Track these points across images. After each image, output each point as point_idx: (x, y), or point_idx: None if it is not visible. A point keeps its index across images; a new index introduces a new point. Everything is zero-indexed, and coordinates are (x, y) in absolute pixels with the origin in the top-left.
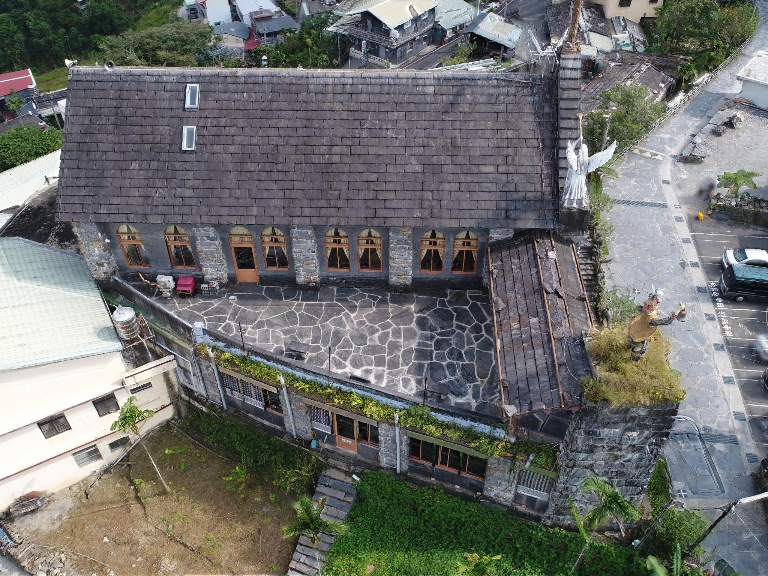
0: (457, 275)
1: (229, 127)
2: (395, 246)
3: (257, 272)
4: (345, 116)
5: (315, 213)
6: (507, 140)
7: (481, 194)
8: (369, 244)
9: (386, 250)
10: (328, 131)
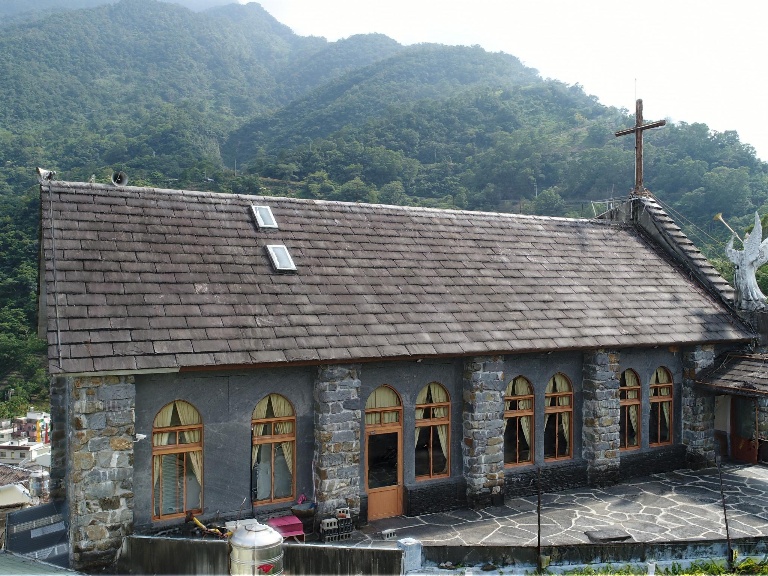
0: (657, 447)
1: (333, 250)
2: (601, 392)
3: (399, 491)
4: (471, 244)
5: (509, 336)
6: (644, 267)
7: (665, 311)
8: (556, 406)
9: (579, 412)
10: (463, 256)
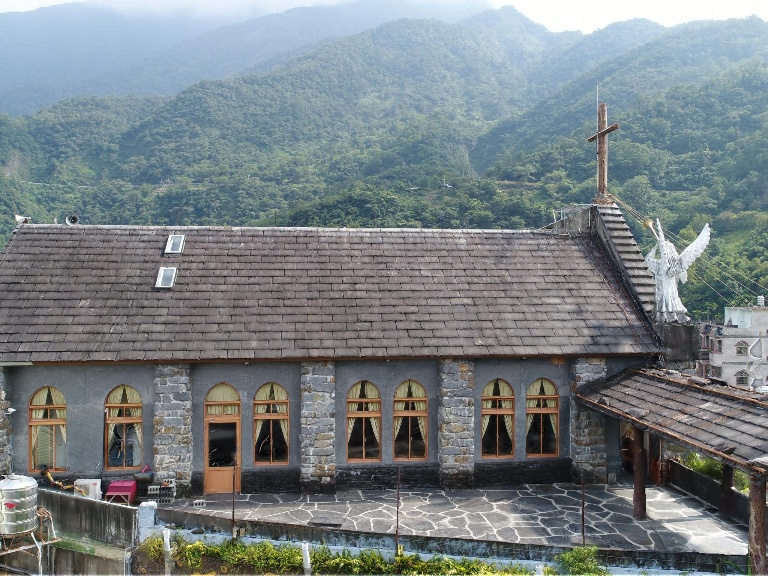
0: (535, 458)
1: (220, 270)
2: (450, 399)
3: (238, 472)
4: (367, 260)
5: (340, 344)
6: (564, 277)
7: (553, 323)
8: (409, 410)
9: (434, 417)
10: (348, 272)
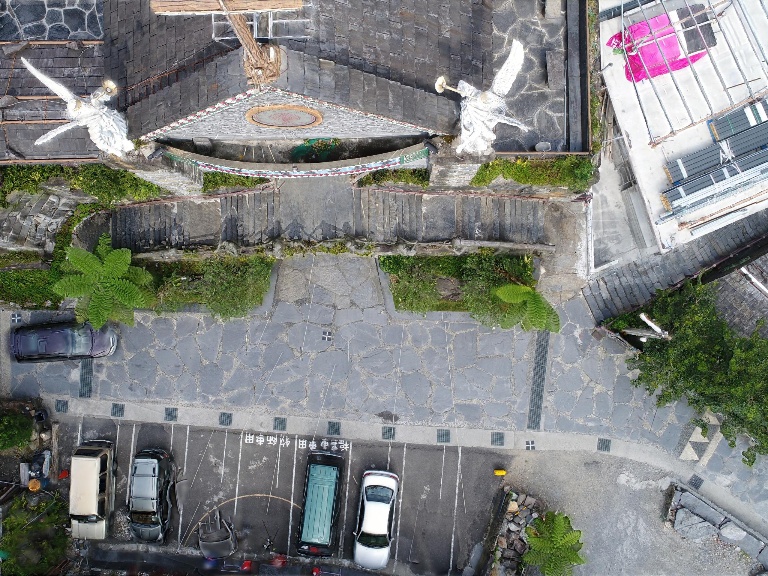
0: None
1: None
2: None
3: None
4: None
5: None
6: None
7: None
8: None
9: None
10: None
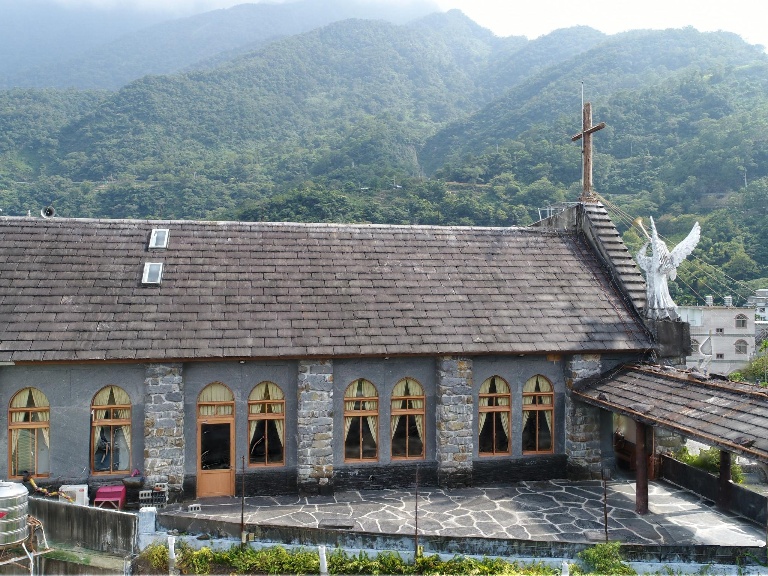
0: (531, 455)
1: (208, 265)
2: (449, 397)
3: (232, 474)
4: (358, 256)
5: (338, 342)
6: (555, 275)
7: (549, 319)
8: (406, 408)
9: (431, 415)
10: (340, 268)
